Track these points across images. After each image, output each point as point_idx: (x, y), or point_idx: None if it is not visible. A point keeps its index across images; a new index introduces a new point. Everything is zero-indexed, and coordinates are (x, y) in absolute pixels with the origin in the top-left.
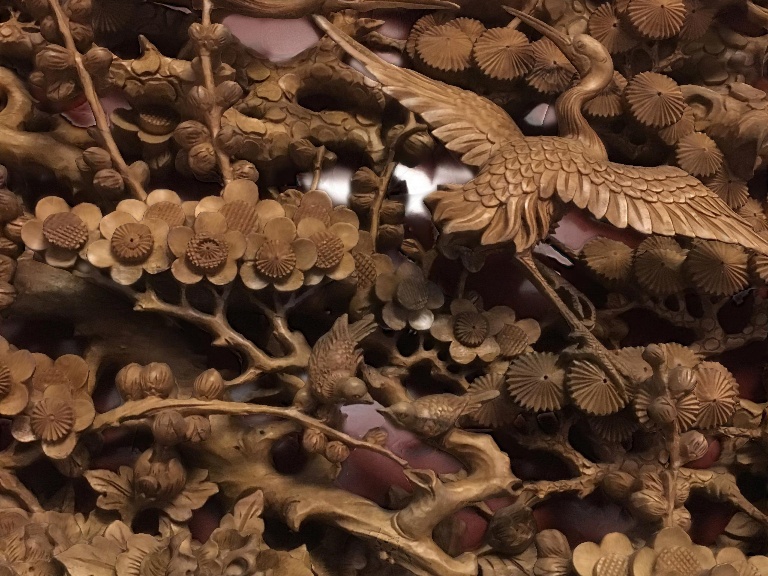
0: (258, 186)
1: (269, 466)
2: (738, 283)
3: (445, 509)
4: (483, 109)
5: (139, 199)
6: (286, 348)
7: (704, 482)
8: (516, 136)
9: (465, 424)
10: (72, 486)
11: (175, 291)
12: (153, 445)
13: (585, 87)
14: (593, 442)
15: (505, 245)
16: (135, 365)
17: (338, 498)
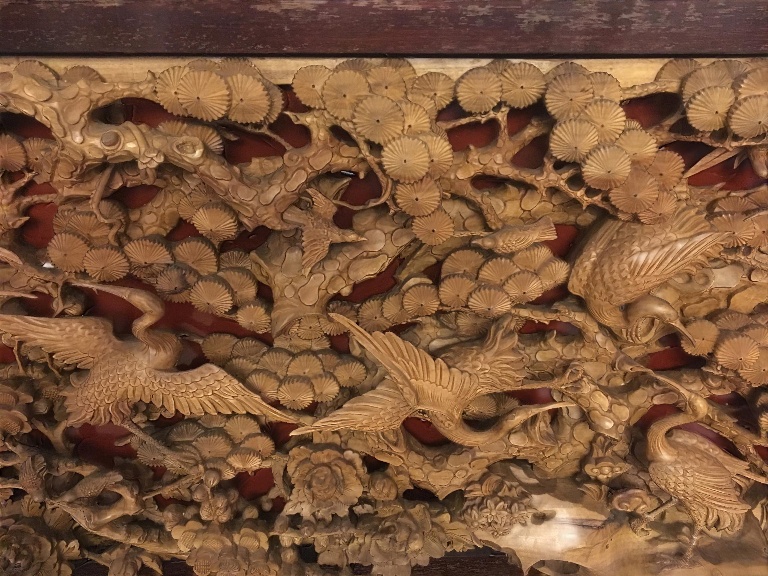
0: None
1: None
2: (273, 398)
3: None
4: (82, 338)
5: None
6: None
7: (266, 467)
8: (109, 348)
9: None
10: None
11: None
12: None
13: (144, 323)
14: None
15: None
16: None
17: None
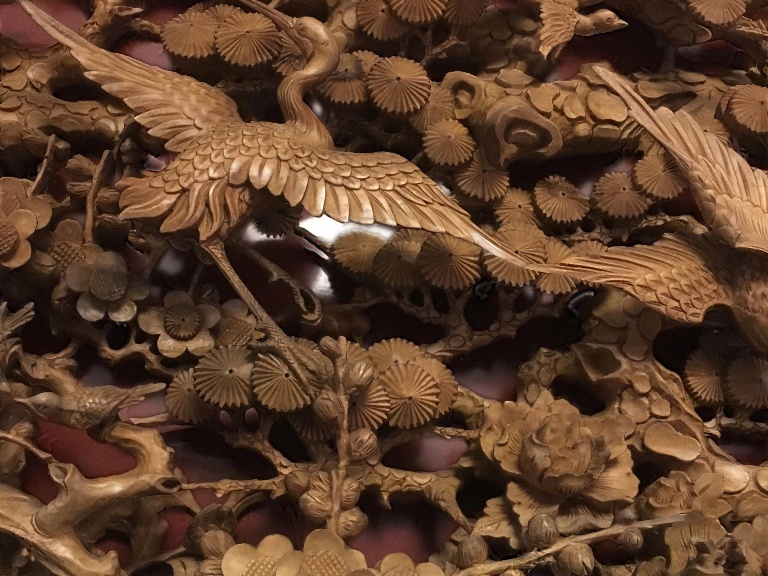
0: (0, 176)
1: None
2: (468, 276)
3: (81, 505)
4: (195, 94)
5: None
6: None
7: (421, 485)
8: (229, 122)
9: (171, 420)
10: None
11: None
12: None
13: (305, 71)
14: (302, 441)
15: (189, 233)
16: None
17: None
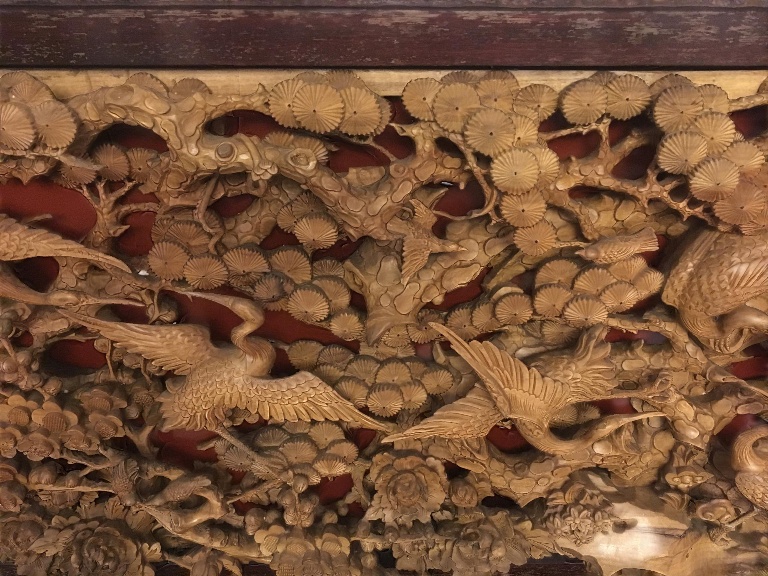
0: None
1: None
2: (361, 405)
3: None
4: (182, 345)
5: None
6: None
7: None
8: (207, 355)
9: None
10: None
11: None
12: None
13: (245, 331)
14: None
15: None
16: (34, 474)
17: None
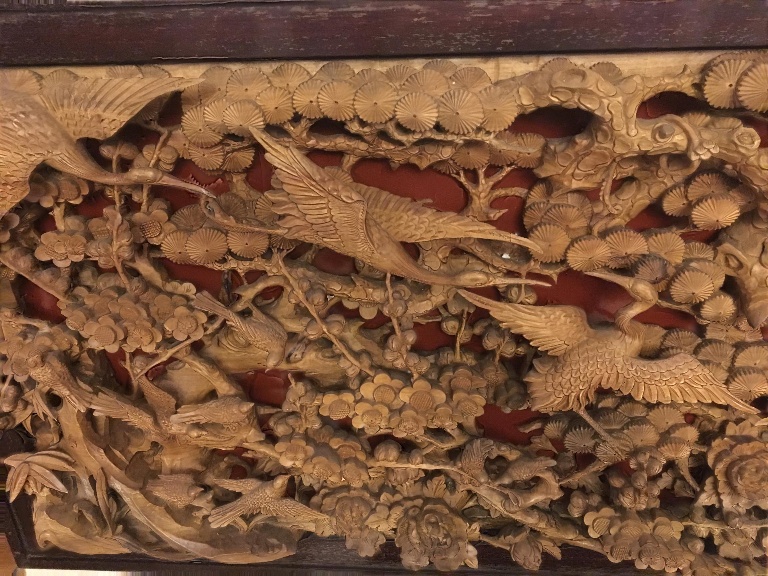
0: None
1: (446, 458)
2: None
3: None
4: (564, 325)
5: None
6: None
7: None
8: (584, 336)
9: None
10: None
11: None
12: None
13: (635, 311)
14: None
15: None
16: (382, 451)
17: None
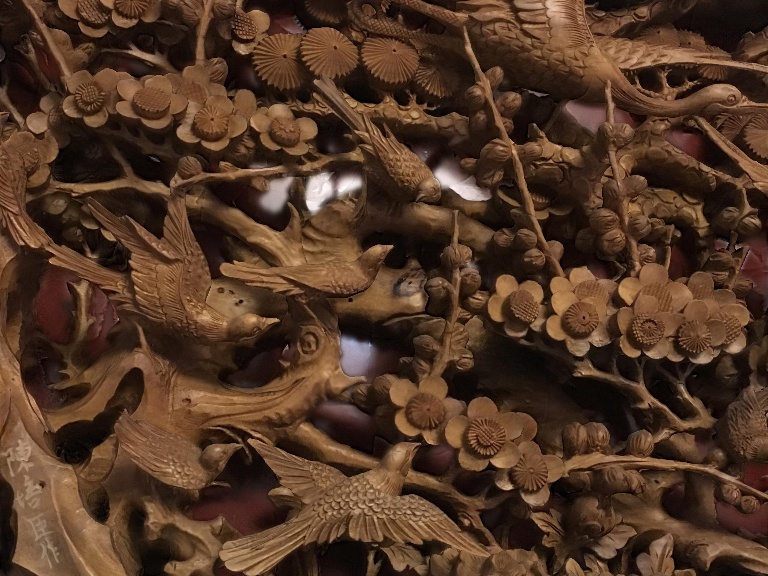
0: None
1: (664, 511)
2: None
3: None
4: None
5: (557, 275)
6: (687, 411)
7: None
8: None
9: None
10: (511, 525)
11: (607, 361)
12: (592, 493)
13: None
14: None
15: None
16: (580, 425)
17: (740, 543)
